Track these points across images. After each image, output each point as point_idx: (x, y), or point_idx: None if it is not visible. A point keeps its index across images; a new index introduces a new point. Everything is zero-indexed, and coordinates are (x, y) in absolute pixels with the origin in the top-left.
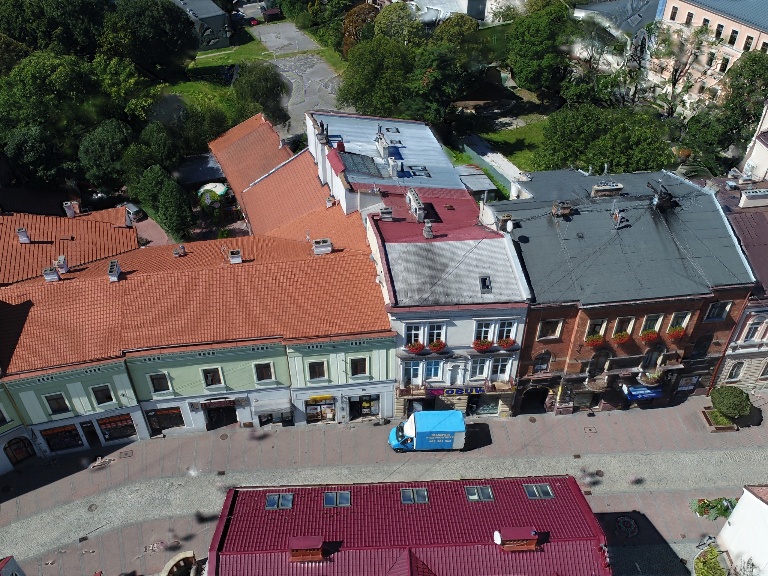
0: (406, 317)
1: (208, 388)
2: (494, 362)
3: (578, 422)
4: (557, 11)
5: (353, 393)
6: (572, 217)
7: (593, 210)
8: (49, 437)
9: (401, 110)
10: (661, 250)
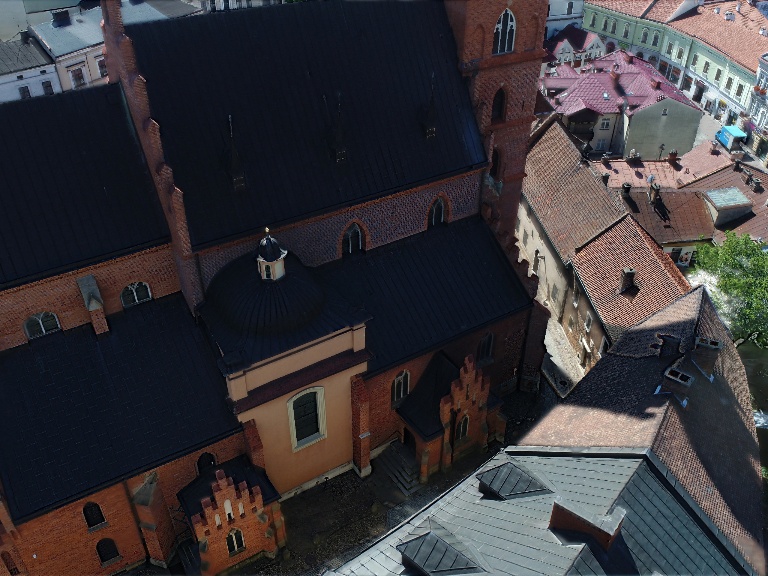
0: None
1: (703, 72)
2: None
3: None
4: None
5: None
6: None
7: None
8: (662, 68)
9: None
10: None
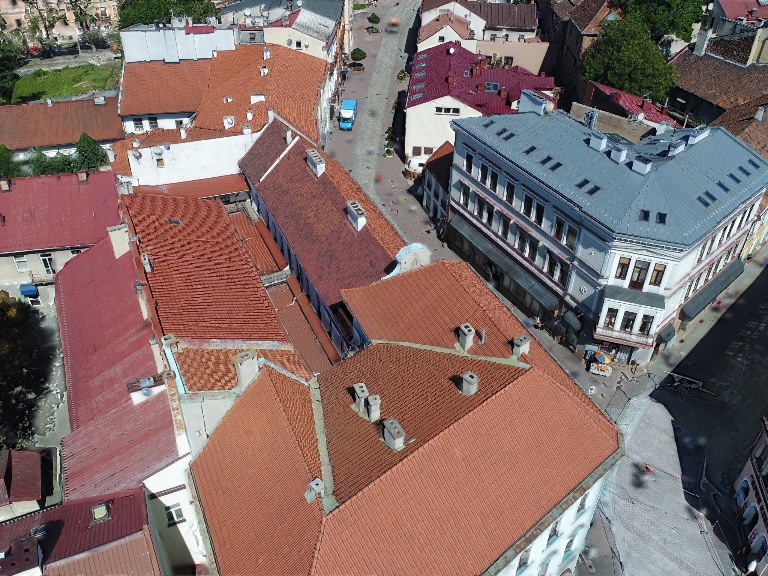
0: None
1: None
2: None
3: (348, 93)
4: None
5: None
6: None
7: None
8: None
9: None
10: None
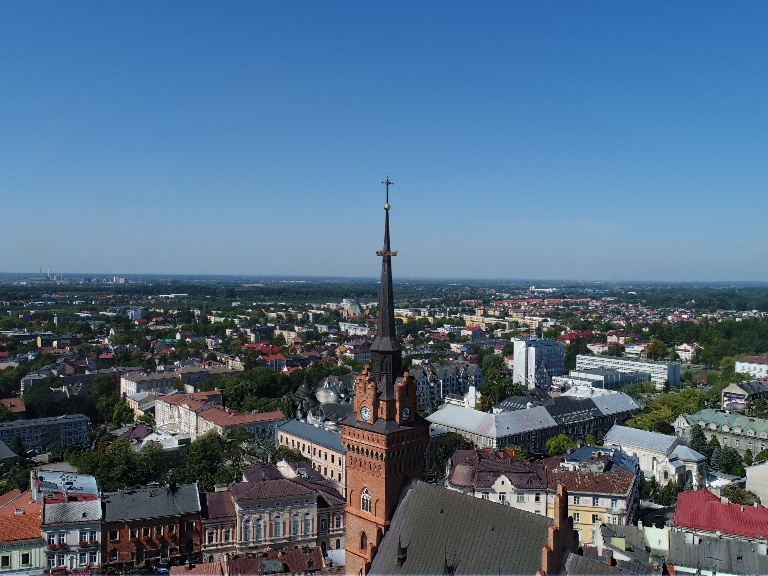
0: (48, 530)
1: None
2: (90, 555)
3: None
4: (212, 439)
5: (22, 575)
6: (133, 494)
7: (143, 491)
8: None
9: (107, 490)
10: (166, 503)
